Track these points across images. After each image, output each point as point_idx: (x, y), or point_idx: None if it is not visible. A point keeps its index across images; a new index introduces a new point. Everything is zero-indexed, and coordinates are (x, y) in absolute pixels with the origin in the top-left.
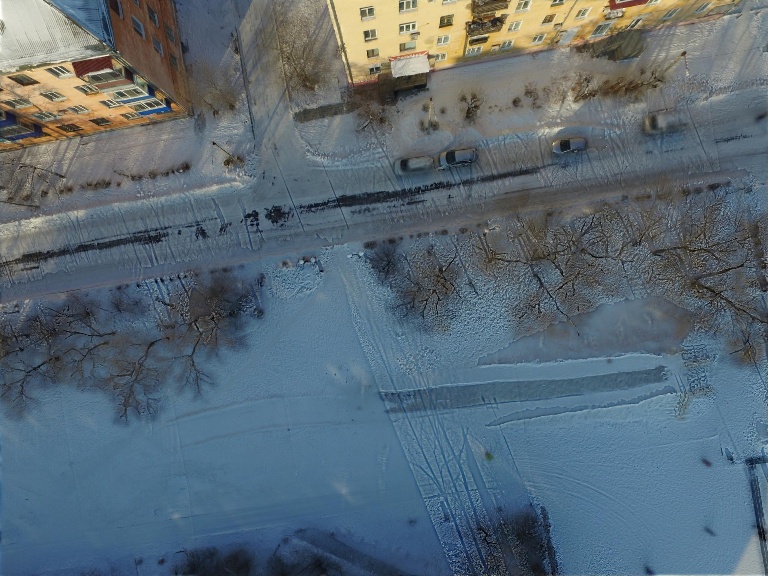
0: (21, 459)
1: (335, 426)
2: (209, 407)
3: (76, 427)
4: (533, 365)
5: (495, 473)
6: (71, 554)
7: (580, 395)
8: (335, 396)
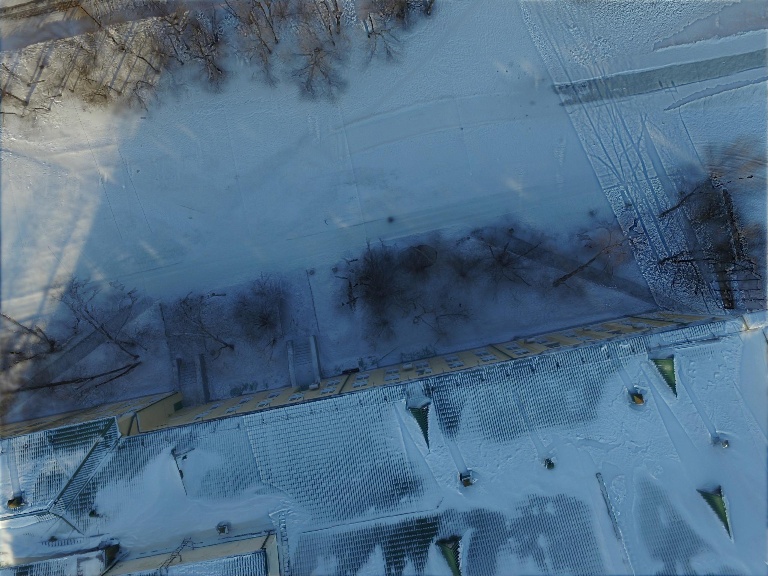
0: (184, 176)
1: (509, 122)
2: (378, 112)
3: (241, 139)
4: (712, 42)
5: (675, 159)
6: (239, 271)
7: (762, 67)
8: (508, 93)
